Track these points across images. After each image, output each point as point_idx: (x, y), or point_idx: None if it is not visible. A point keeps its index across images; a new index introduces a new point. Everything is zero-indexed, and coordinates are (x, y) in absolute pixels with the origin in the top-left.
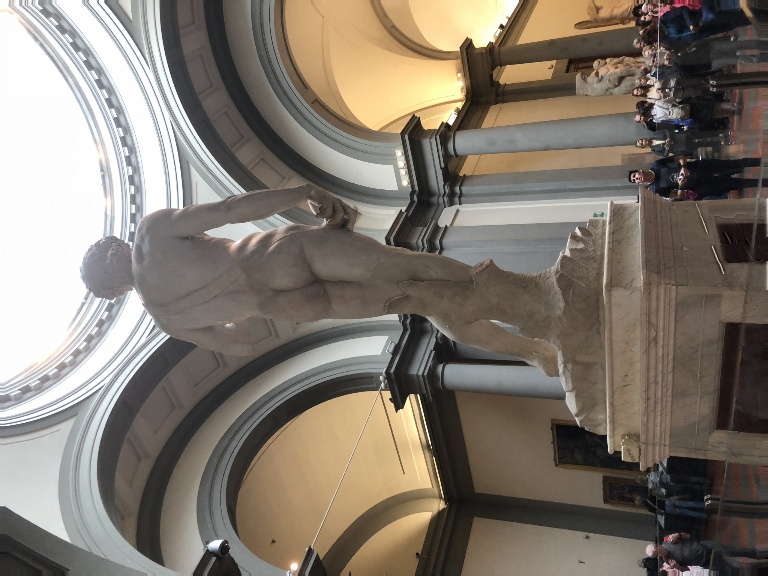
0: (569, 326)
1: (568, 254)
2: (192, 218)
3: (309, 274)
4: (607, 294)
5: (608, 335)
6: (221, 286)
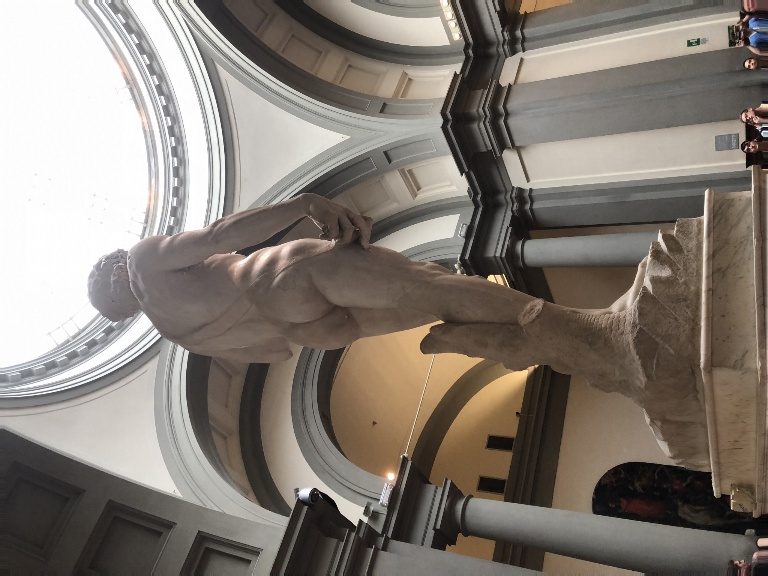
0: (654, 397)
1: (649, 287)
2: (180, 254)
3: (326, 305)
4: (706, 375)
5: (709, 409)
6: (233, 318)
